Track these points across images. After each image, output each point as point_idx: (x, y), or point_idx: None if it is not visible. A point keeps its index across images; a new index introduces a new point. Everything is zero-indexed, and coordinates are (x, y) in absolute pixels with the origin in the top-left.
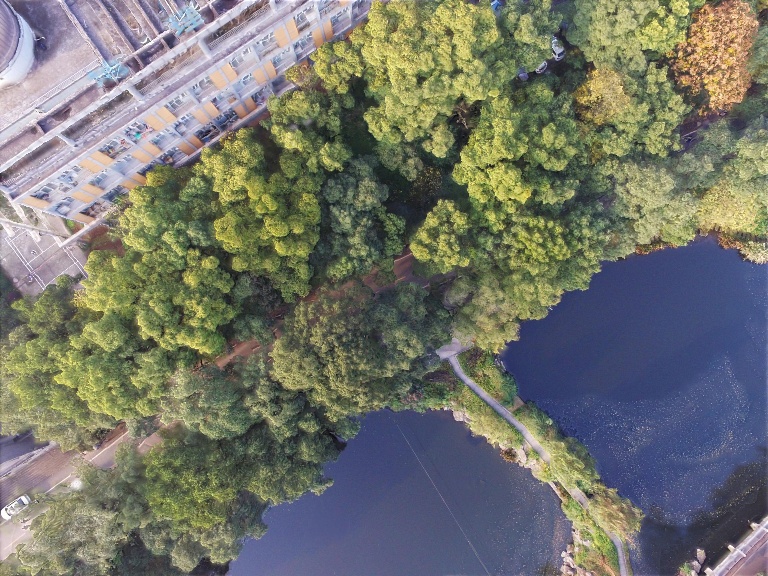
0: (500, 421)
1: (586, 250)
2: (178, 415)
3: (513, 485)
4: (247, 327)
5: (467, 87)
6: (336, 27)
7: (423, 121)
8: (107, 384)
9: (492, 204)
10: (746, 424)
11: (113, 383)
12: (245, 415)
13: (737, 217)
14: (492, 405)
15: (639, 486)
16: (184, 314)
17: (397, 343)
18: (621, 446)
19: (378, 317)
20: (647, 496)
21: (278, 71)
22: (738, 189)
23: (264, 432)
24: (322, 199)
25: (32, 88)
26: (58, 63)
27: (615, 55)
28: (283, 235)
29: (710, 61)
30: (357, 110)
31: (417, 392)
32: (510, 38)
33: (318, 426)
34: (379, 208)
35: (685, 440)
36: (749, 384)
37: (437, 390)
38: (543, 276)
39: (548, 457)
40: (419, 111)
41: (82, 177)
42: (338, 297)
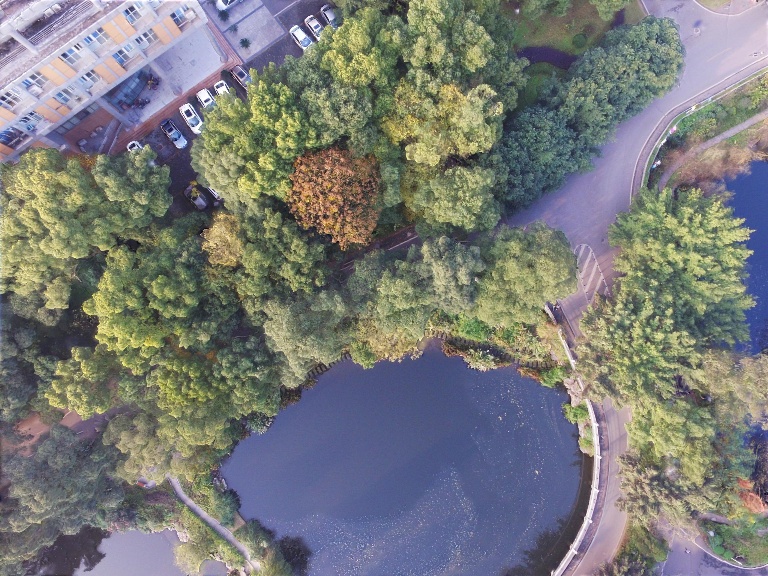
0: (197, 551)
1: (235, 389)
2: None
3: None
4: None
5: (53, 250)
6: None
7: None
8: None
9: (131, 348)
10: (474, 538)
11: None
12: None
13: (391, 349)
14: (213, 525)
15: None
16: None
17: None
18: (346, 565)
19: (6, 471)
20: None
21: None
22: (379, 324)
23: None
24: None
25: None
26: None
27: None
28: None
29: (315, 208)
30: None
31: (121, 520)
32: None
33: None
34: (26, 353)
35: (412, 557)
36: (476, 496)
37: (156, 512)
38: (192, 417)
39: None
40: (21, 270)
41: None
42: None
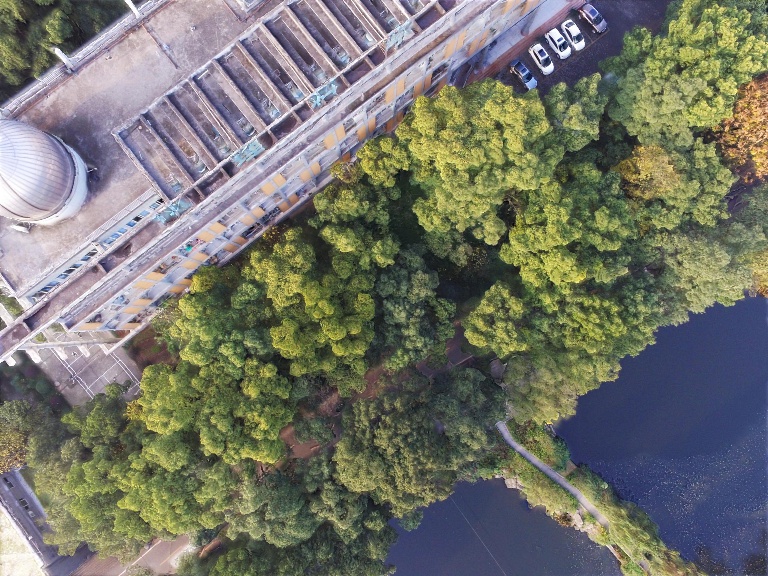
0: (558, 492)
1: (641, 324)
2: (244, 529)
3: (570, 550)
4: (306, 428)
5: (521, 180)
6: (379, 120)
7: (475, 212)
8: (171, 504)
9: (545, 285)
10: None
11: (177, 503)
12: (310, 521)
13: None
14: (544, 471)
15: (698, 543)
16: (244, 425)
17: (460, 435)
18: (677, 504)
19: (439, 409)
20: (707, 553)
21: (322, 167)
22: None
23: (329, 534)
24: (375, 294)
25: (87, 221)
26: (112, 193)
27: (660, 130)
28: (341, 338)
29: (758, 135)
30: (405, 202)
31: None
32: (557, 124)
33: (383, 524)
34: None
35: (740, 493)
36: None
37: (488, 459)
38: (599, 353)
39: (604, 520)
40: (471, 204)
41: (134, 295)
42: (396, 391)
